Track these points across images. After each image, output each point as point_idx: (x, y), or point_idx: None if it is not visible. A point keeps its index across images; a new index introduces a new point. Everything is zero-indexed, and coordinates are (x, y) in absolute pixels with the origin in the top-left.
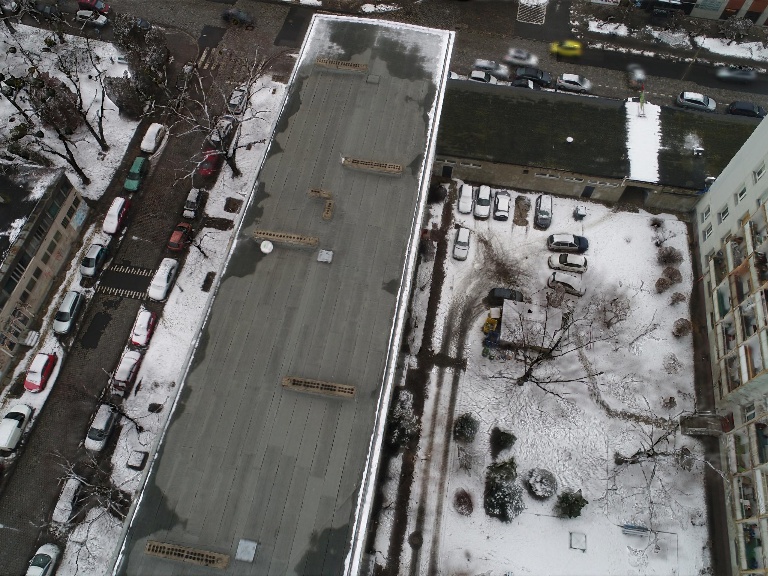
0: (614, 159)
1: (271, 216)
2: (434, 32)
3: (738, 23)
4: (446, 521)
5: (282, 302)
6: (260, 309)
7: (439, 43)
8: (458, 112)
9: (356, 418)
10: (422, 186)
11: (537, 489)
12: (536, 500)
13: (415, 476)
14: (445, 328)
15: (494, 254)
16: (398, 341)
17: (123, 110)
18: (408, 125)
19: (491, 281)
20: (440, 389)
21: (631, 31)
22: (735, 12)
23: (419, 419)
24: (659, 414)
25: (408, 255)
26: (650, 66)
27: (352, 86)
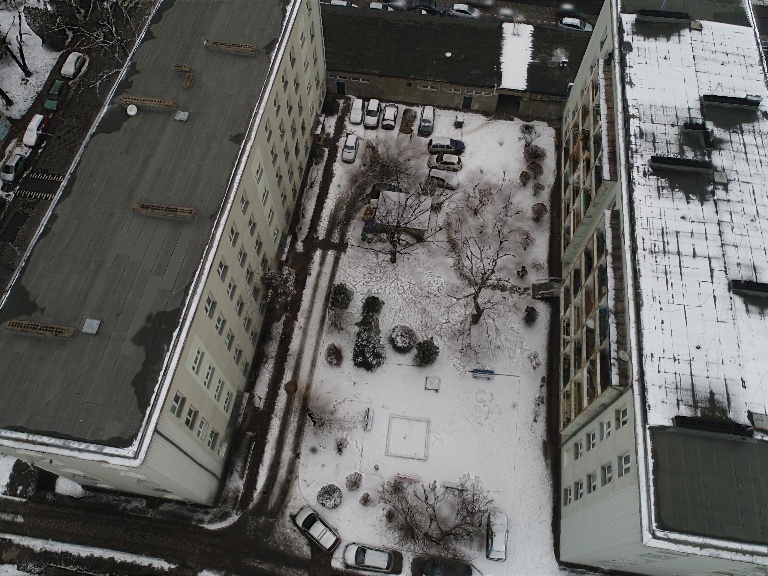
0: (488, 71)
1: (139, 88)
2: None
3: None
4: (319, 372)
5: (141, 151)
6: (122, 157)
7: None
8: (350, 34)
9: (195, 234)
10: (274, 64)
11: (398, 341)
12: (399, 353)
13: (294, 337)
14: (330, 218)
15: (380, 157)
16: (239, 179)
17: (44, 40)
18: (267, 16)
19: (375, 180)
20: (322, 268)
21: None
22: None
23: (301, 292)
24: (514, 283)
25: (255, 116)
26: None
27: None
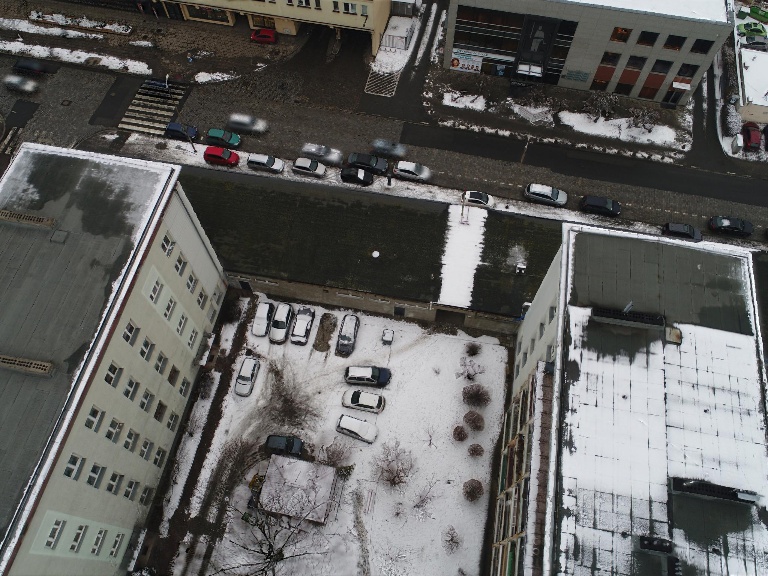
0: (424, 277)
1: None
2: (153, 169)
3: (602, 100)
4: None
5: None
6: None
7: (155, 184)
8: (259, 217)
9: None
10: (77, 388)
11: None
12: None
13: None
14: (209, 484)
15: (283, 388)
16: None
17: None
18: (83, 301)
19: (273, 423)
20: (188, 563)
21: (489, 105)
22: (605, 83)
23: None
24: None
25: (29, 490)
26: (503, 148)
27: (32, 246)
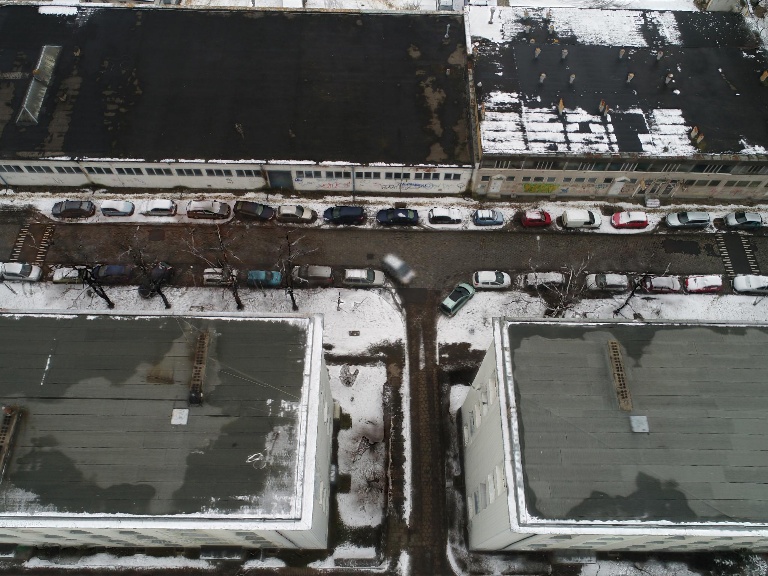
0: None
1: None
2: None
3: None
4: None
5: None
6: None
7: None
8: None
9: None
10: None
11: None
12: None
13: None
14: None
15: None
16: None
17: None
18: None
19: None
20: None
21: None
22: None
23: None
24: None
25: None
26: None
27: None
